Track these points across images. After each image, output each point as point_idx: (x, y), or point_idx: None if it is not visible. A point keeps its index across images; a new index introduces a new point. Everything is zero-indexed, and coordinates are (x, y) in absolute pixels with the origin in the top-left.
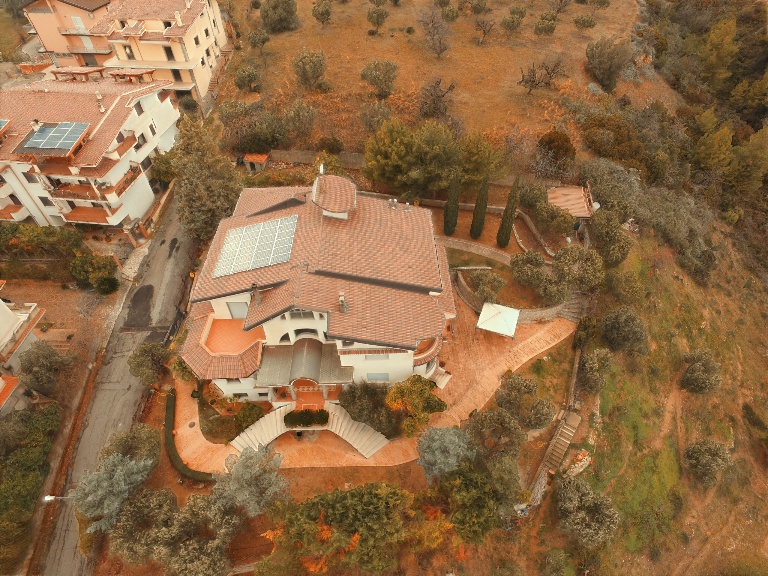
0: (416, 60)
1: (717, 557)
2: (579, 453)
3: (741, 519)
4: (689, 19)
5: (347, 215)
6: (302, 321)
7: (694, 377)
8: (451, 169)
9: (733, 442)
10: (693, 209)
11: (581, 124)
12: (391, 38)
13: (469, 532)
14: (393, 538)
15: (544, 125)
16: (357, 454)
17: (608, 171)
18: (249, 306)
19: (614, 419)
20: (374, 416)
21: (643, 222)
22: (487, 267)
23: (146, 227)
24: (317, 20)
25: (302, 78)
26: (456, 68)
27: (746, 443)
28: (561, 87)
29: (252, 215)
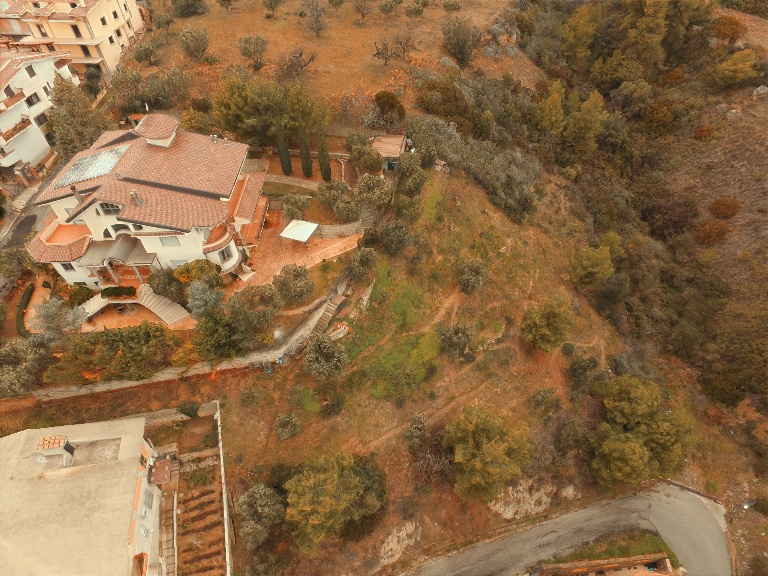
0: (298, 38)
1: (460, 411)
2: (340, 324)
3: (490, 387)
4: (570, 7)
5: (169, 144)
6: (114, 217)
7: (463, 279)
8: (283, 118)
9: (501, 334)
10: (517, 160)
11: (418, 88)
12: (284, 21)
13: (204, 351)
14: (143, 351)
15: (389, 89)
16: (162, 322)
17: (429, 124)
18: (75, 207)
19: (384, 306)
20: (167, 288)
21: (453, 165)
22: (308, 197)
23: (37, 171)
24: (220, 5)
25: (187, 51)
26: (330, 44)
27: (516, 337)
28: (414, 59)
29: (99, 147)
